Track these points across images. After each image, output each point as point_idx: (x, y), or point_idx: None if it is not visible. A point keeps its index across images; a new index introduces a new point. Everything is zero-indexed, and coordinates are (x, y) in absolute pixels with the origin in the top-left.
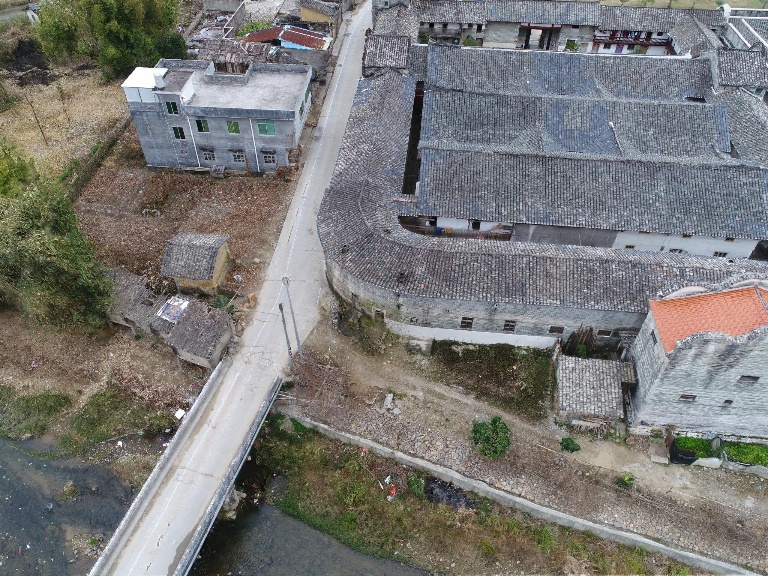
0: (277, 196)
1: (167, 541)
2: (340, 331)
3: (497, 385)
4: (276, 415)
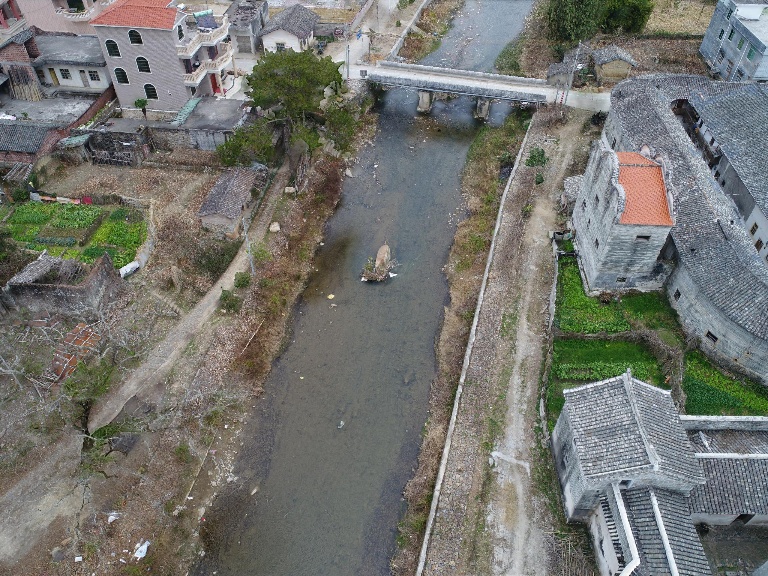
0: None
1: None
2: None
3: None
4: None
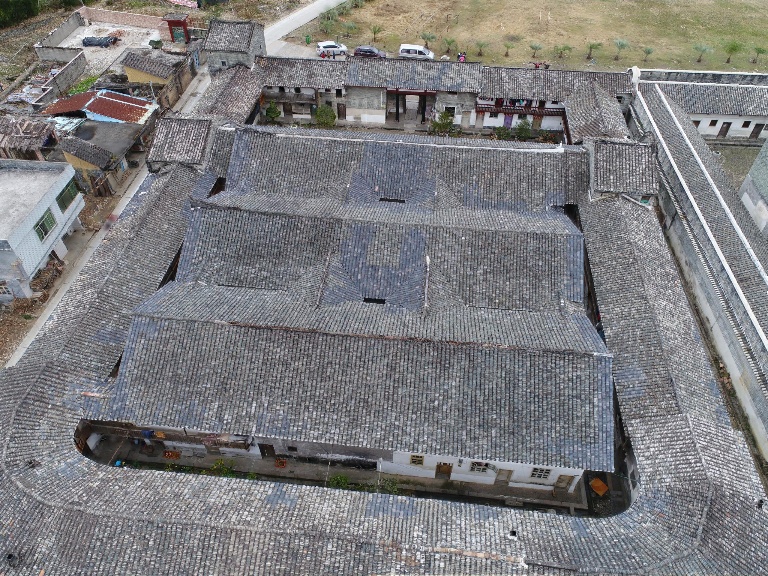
0: (4, 342)
1: None
2: None
3: None
4: None
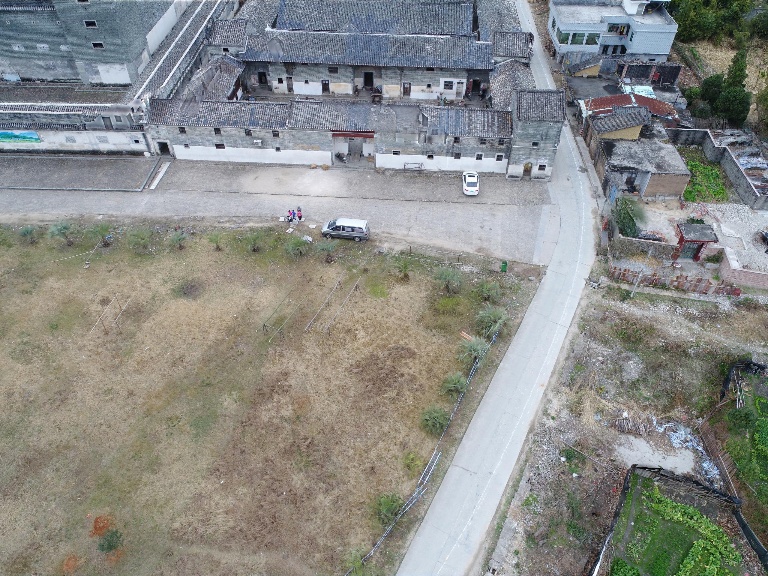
0: None
1: None
2: None
3: None
4: None
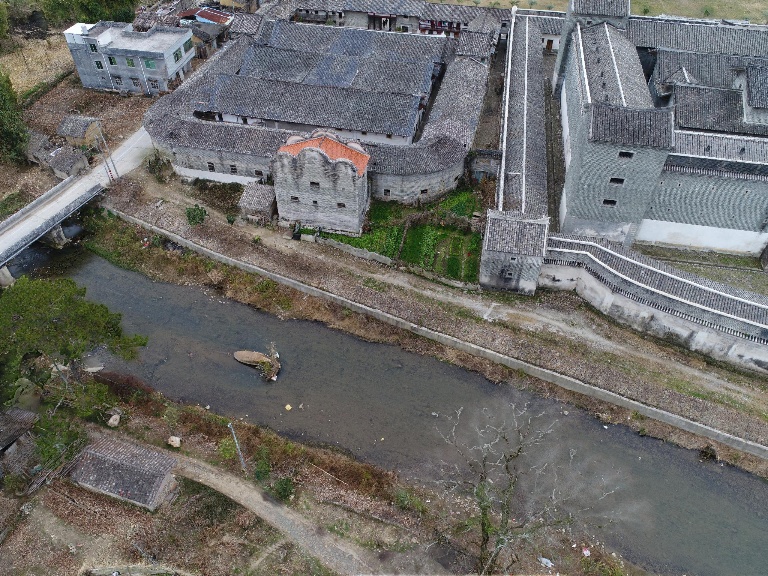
0: None
1: (15, 239)
2: (149, 171)
3: (222, 201)
4: (101, 209)
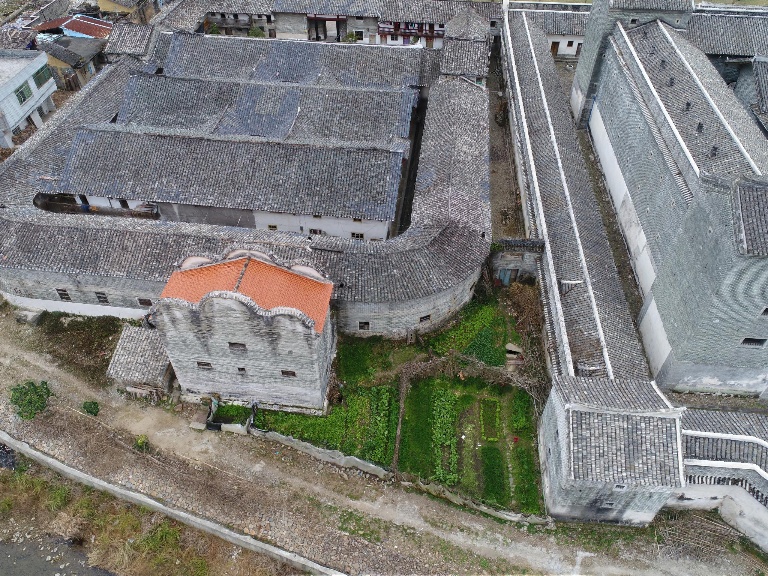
0: None
1: None
2: None
3: (85, 354)
4: None
